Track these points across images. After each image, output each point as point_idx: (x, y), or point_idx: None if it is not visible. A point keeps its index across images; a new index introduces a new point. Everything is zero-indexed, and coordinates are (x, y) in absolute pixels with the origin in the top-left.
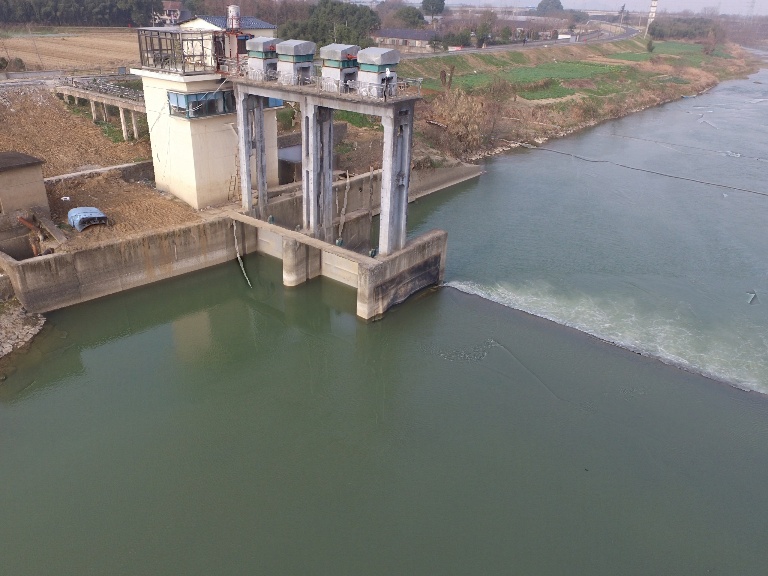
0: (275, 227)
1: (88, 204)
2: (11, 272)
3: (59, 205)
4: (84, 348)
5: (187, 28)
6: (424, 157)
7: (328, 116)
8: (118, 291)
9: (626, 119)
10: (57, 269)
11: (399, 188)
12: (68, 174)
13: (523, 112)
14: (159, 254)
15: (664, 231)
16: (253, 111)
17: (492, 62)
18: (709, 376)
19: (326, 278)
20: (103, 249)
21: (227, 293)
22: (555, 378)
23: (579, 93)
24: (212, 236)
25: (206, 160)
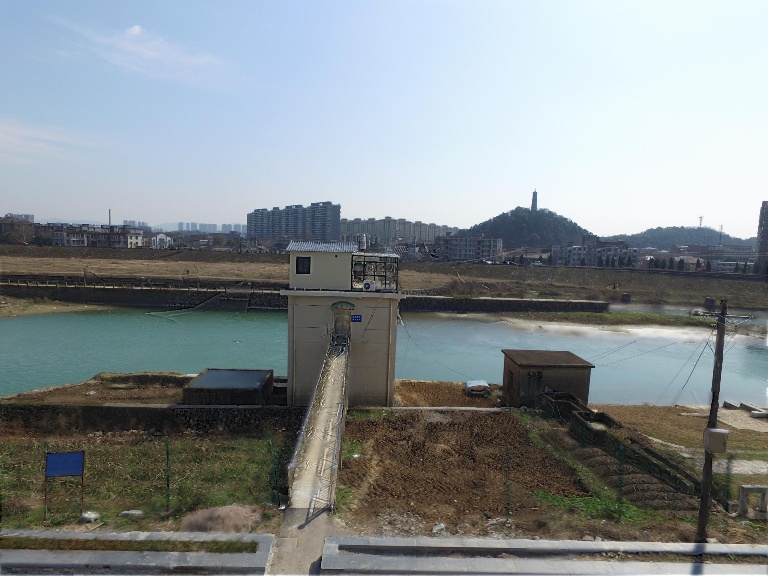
0: None
1: None
2: None
3: None
4: None
5: None
6: None
7: None
8: None
9: None
10: None
11: None
12: (469, 408)
13: None
14: None
15: None
16: None
17: None
18: None
19: None
20: None
21: None
22: None
23: None
24: None
25: None
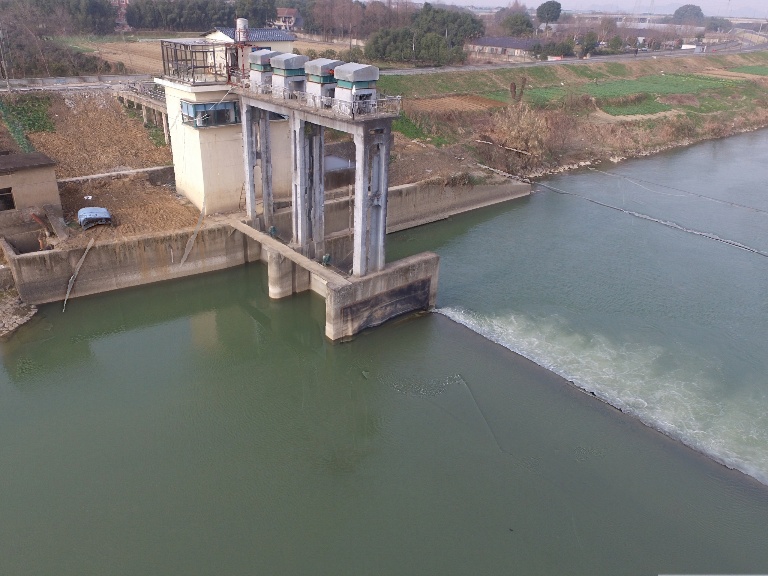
0: (266, 238)
1: (105, 204)
2: (10, 264)
3: (79, 204)
4: (78, 340)
5: (206, 40)
6: (461, 173)
7: (318, 131)
8: (113, 289)
9: (731, 139)
10: (52, 265)
11: (377, 208)
12: (97, 175)
13: (601, 128)
14: (155, 257)
15: (713, 270)
16: (258, 122)
17: (585, 74)
18: (693, 445)
19: (314, 293)
20: (98, 249)
21: (227, 299)
22: (507, 426)
23: (676, 109)
24: (211, 242)
25: (216, 168)
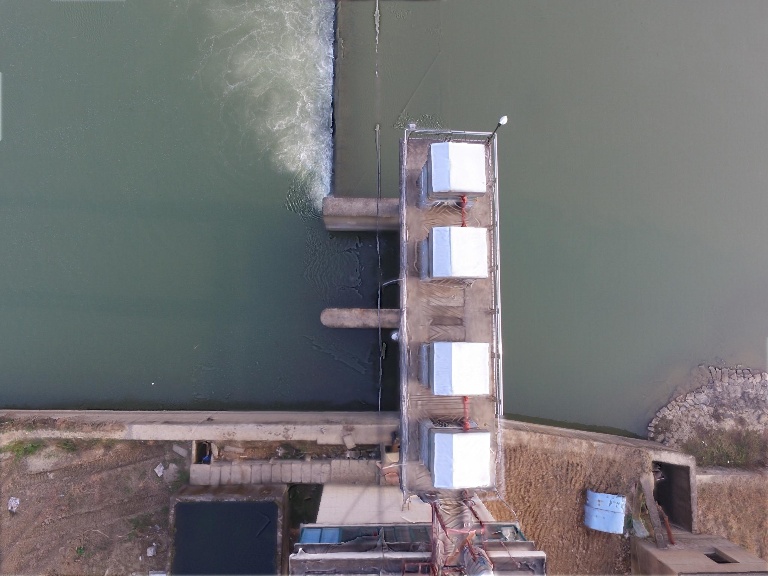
0: None
1: (575, 575)
2: None
3: None
4: None
5: None
6: (4, 433)
7: None
8: None
9: None
10: None
11: None
12: None
13: None
14: None
15: None
16: None
17: None
18: None
19: None
20: None
21: None
22: (420, 60)
23: None
24: None
25: None
